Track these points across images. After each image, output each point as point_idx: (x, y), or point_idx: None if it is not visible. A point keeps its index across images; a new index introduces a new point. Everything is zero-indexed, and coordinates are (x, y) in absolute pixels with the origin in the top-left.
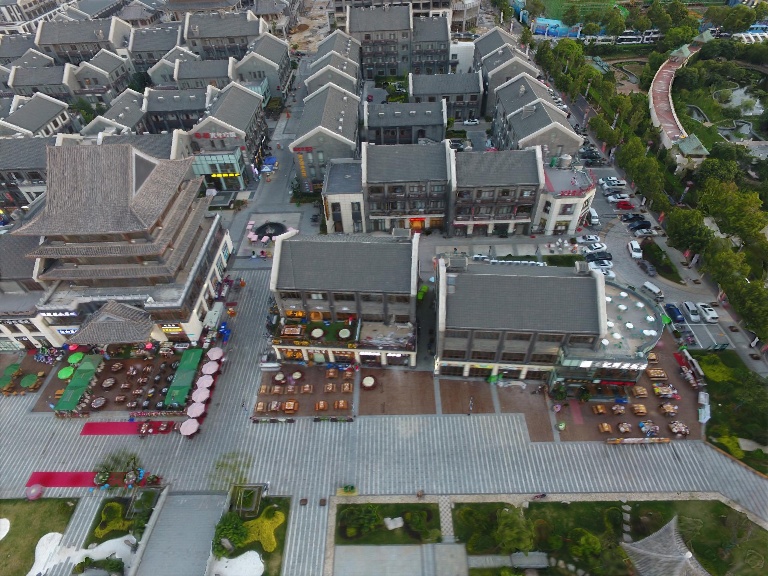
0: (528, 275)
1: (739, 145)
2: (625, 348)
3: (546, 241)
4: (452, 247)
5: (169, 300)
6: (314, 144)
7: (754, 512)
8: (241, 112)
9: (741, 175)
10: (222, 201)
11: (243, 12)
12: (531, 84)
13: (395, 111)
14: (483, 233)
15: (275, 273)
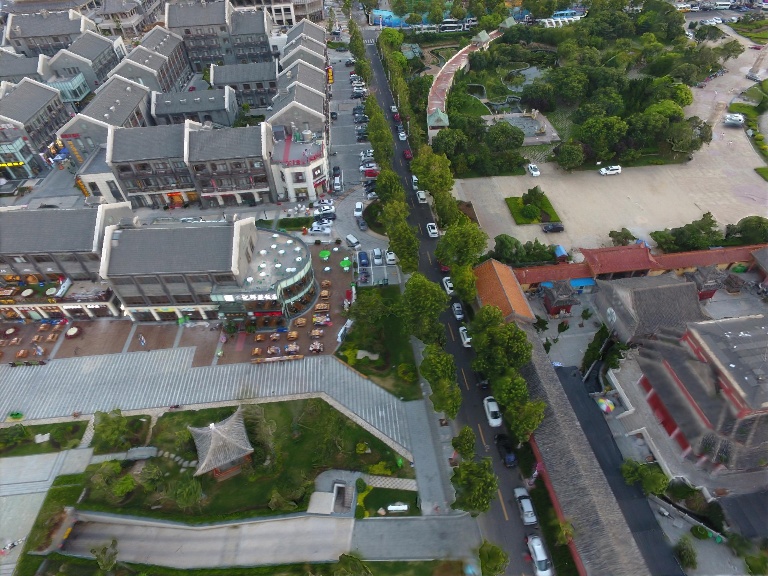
0: (181, 227)
1: (472, 116)
2: (266, 283)
3: (288, 207)
4: (203, 217)
5: None
6: (79, 131)
7: (344, 404)
8: (27, 105)
9: (465, 141)
10: (8, 189)
11: (66, 11)
12: (303, 69)
13: (181, 99)
14: (235, 203)
15: None
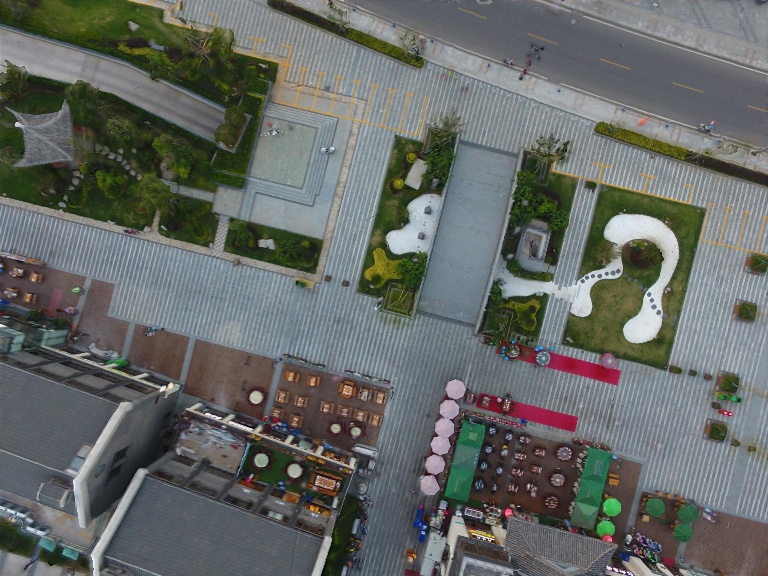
0: None
1: None
2: None
3: None
4: None
5: (481, 575)
6: None
7: None
8: None
9: None
10: None
11: None
12: None
13: None
14: None
15: (318, 564)
